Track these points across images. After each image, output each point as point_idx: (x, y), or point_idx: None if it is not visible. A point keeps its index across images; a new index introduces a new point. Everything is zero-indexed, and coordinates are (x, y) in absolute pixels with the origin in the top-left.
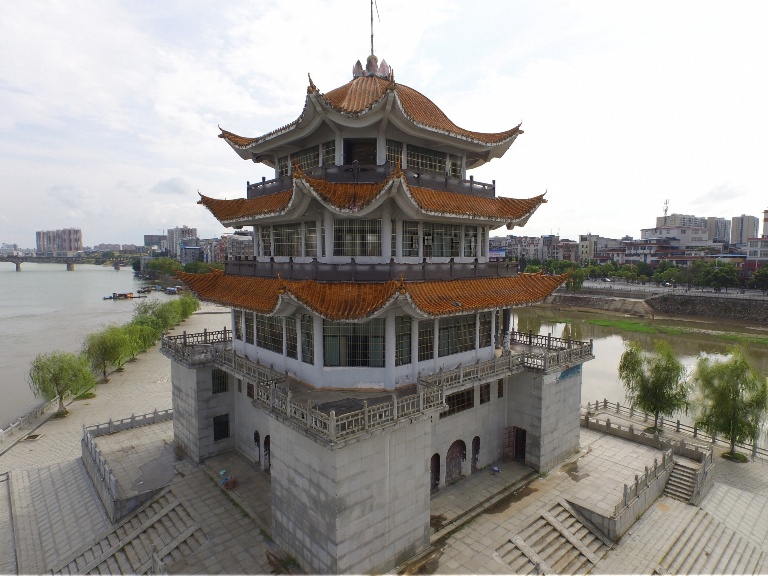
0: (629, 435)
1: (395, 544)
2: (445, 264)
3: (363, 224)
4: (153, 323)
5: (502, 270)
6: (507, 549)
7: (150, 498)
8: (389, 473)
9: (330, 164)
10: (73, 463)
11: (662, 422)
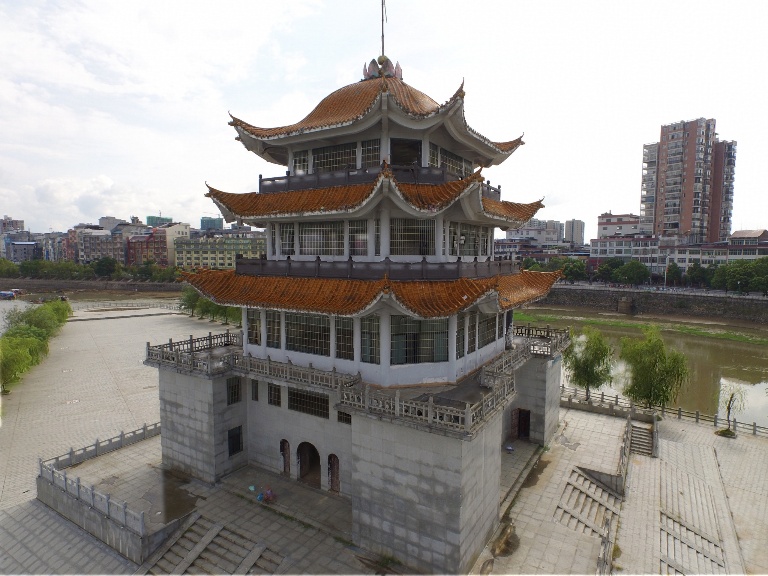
0: (588, 407)
1: (485, 525)
2: (486, 262)
3: (418, 224)
4: (35, 334)
5: (512, 268)
6: (560, 514)
7: (178, 528)
8: (484, 459)
9: (373, 162)
10: (28, 507)
11: (589, 395)
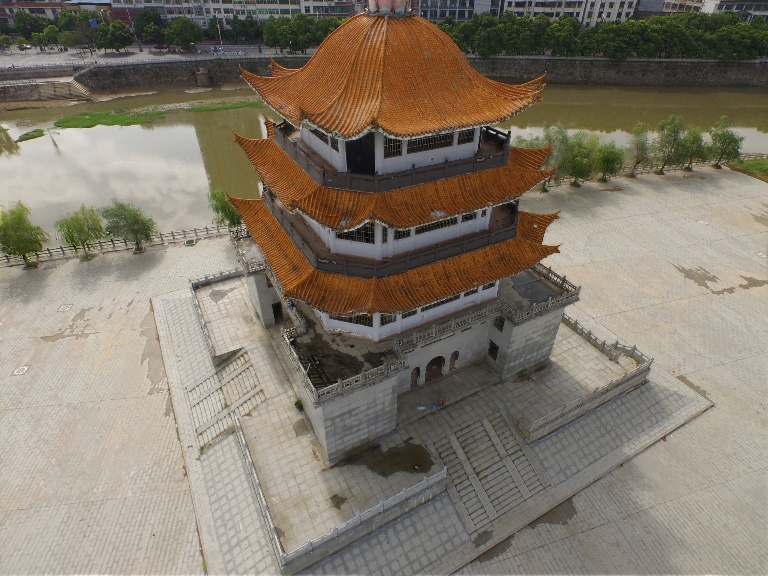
0: None
1: None
2: None
3: None
4: None
5: None
6: None
7: None
8: None
9: (468, 139)
10: None
11: None
